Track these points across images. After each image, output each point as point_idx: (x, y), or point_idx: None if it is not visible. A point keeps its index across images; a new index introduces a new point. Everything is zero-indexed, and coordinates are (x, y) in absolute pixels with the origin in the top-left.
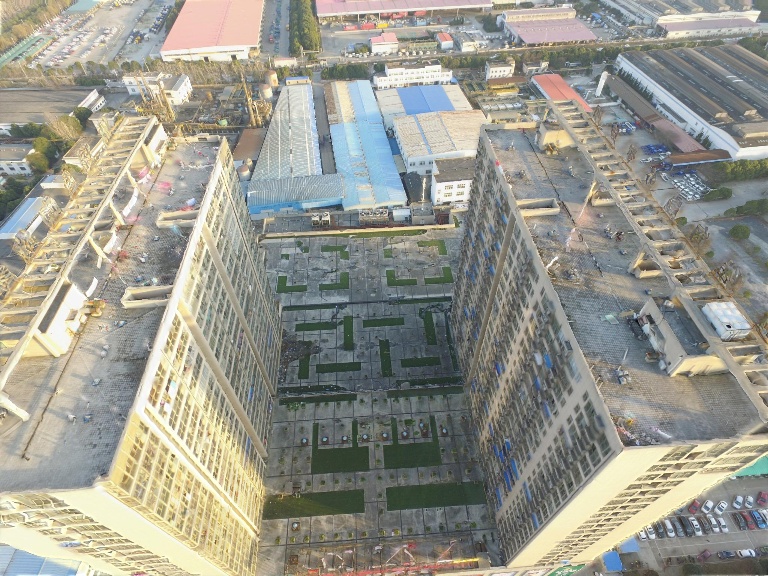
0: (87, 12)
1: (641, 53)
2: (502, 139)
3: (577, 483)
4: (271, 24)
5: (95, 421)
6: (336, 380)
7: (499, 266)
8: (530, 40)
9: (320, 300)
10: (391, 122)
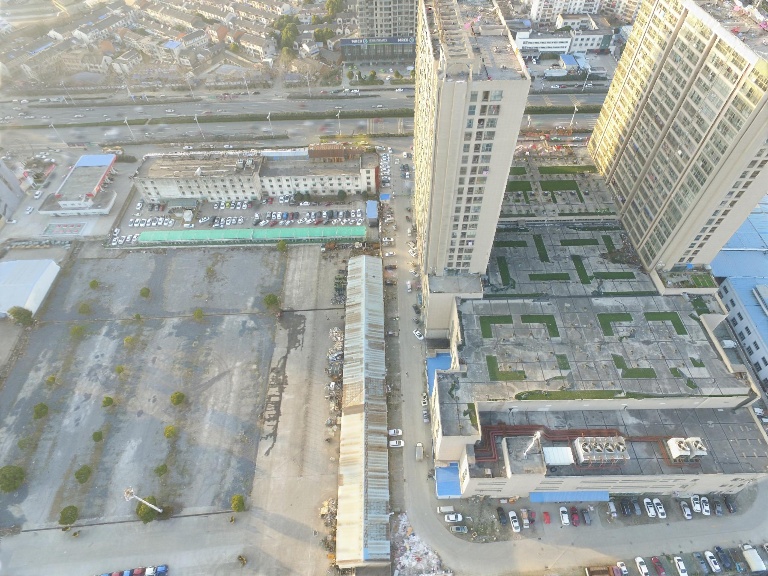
0: None
1: None
2: (510, 76)
3: None
4: None
5: None
6: (578, 233)
7: None
8: None
9: (623, 301)
10: None
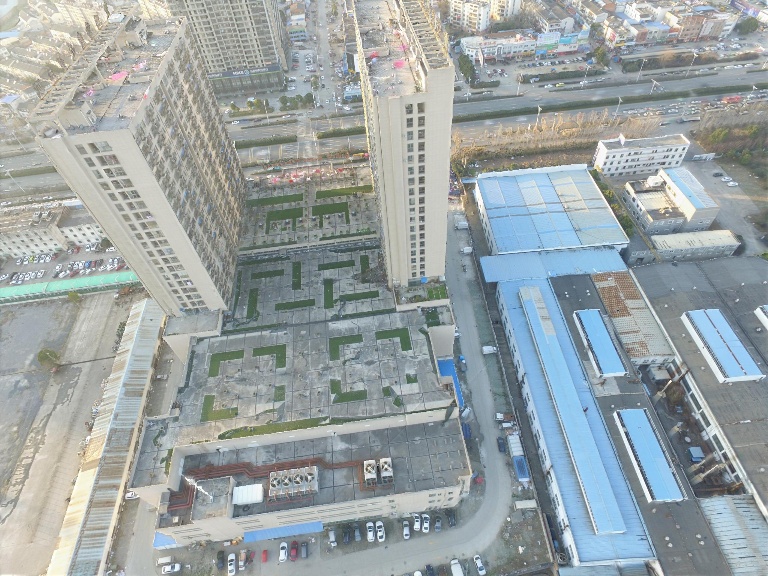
0: None
1: None
2: (120, 126)
3: None
4: None
5: (369, 8)
6: (337, 256)
7: (181, 132)
8: None
9: (359, 322)
10: None
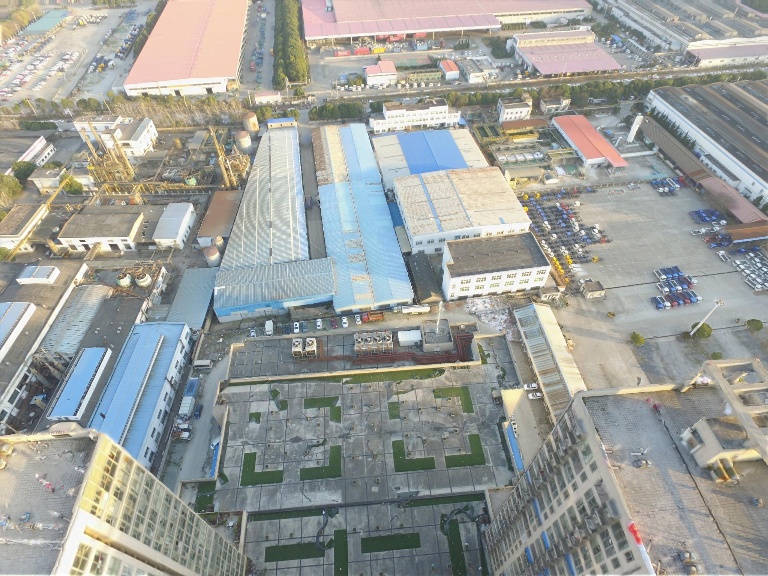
0: (47, 33)
1: (677, 90)
2: (619, 428)
3: None
4: (253, 47)
5: None
6: None
7: None
8: (546, 70)
9: (301, 500)
10: (391, 181)
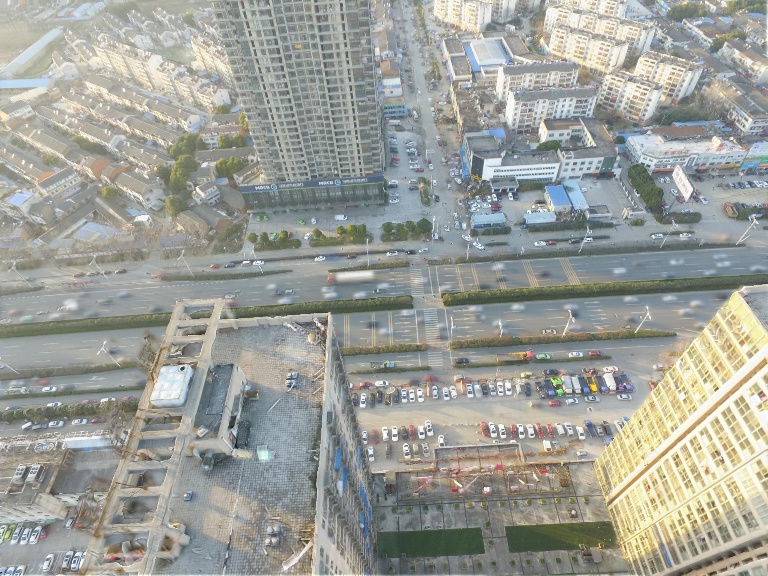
0: None
1: None
2: None
3: (344, 373)
4: None
5: None
6: None
7: None
8: None
9: None
10: None
